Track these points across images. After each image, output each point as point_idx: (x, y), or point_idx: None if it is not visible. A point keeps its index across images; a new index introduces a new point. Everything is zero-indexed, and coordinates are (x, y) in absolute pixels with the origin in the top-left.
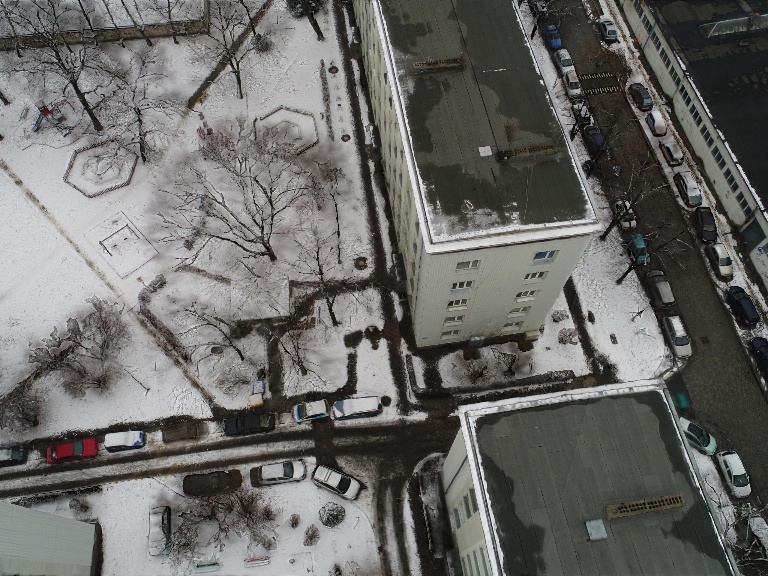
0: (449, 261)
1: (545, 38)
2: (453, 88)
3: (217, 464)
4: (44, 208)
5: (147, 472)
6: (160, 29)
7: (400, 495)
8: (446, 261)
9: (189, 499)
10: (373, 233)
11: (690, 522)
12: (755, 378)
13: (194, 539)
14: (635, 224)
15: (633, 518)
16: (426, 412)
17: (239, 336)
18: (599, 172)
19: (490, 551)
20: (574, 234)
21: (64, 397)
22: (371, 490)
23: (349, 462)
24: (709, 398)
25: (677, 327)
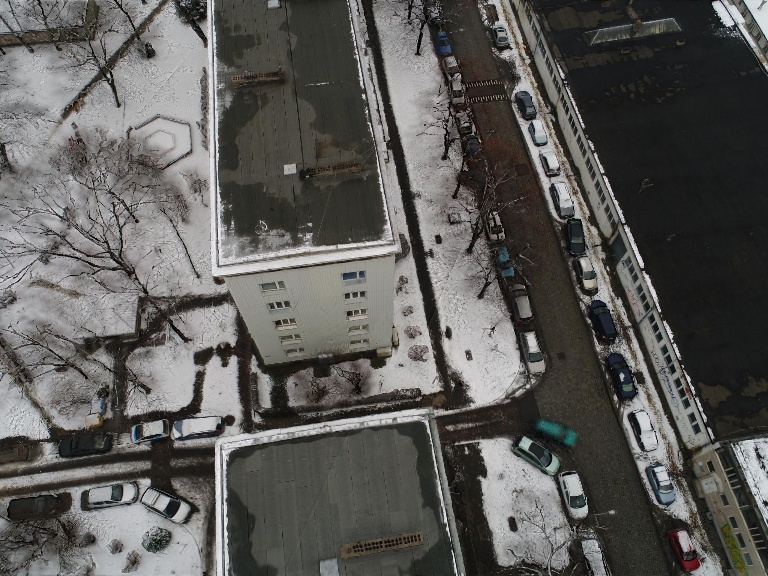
0: (248, 283)
1: (436, 45)
2: (270, 103)
3: (48, 487)
4: None
5: None
6: (41, 35)
7: None
8: (244, 283)
9: (14, 524)
10: None
11: (430, 561)
12: (608, 395)
13: (4, 567)
14: (503, 236)
15: (370, 557)
16: None
17: (85, 354)
18: (472, 183)
19: None
20: (368, 256)
21: None
22: (203, 513)
23: (184, 484)
24: (559, 416)
25: (531, 343)
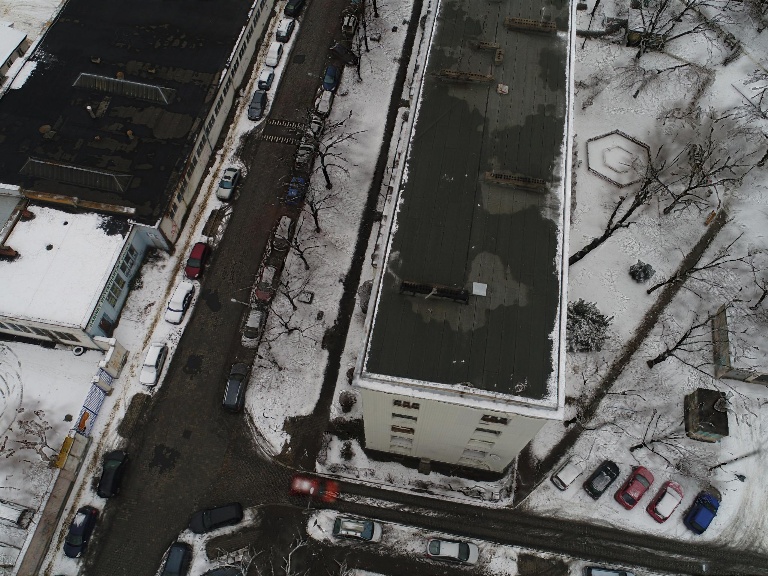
0: None
1: None
2: None
3: None
4: None
5: None
6: None
7: None
8: None
9: None
10: None
11: None
12: None
13: None
14: None
15: None
16: None
17: None
18: None
19: None
20: None
21: None
22: None
23: None
24: None
25: None
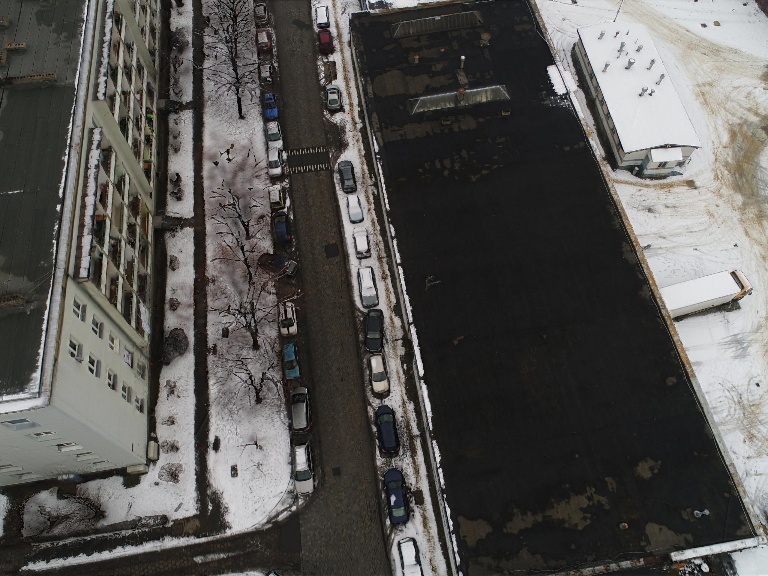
0: None
1: (263, 107)
2: None
3: None
4: None
5: None
6: None
7: None
8: None
9: None
10: None
11: None
12: (380, 518)
13: None
14: (294, 330)
15: None
16: None
17: None
18: (271, 268)
19: None
20: (6, 412)
21: None
22: None
23: None
24: (321, 544)
25: (299, 459)
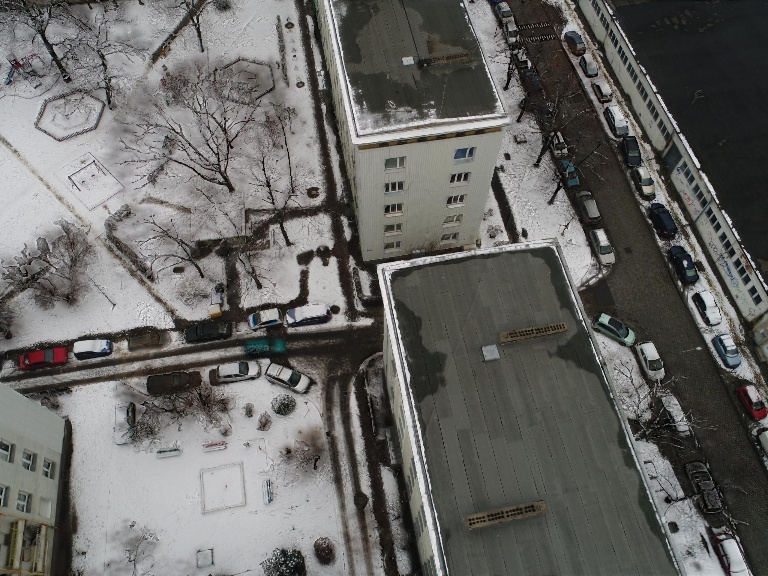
0: (377, 157)
1: None
2: (382, 11)
3: (179, 367)
4: (16, 151)
5: (114, 376)
6: None
7: (347, 388)
8: (374, 157)
9: (152, 397)
10: (325, 166)
11: (572, 346)
12: (672, 281)
13: (155, 424)
14: (566, 152)
15: (523, 343)
16: (372, 318)
17: (199, 257)
18: None
19: (399, 374)
20: (485, 127)
21: (36, 313)
22: (320, 385)
23: (300, 362)
24: (630, 299)
25: (601, 238)
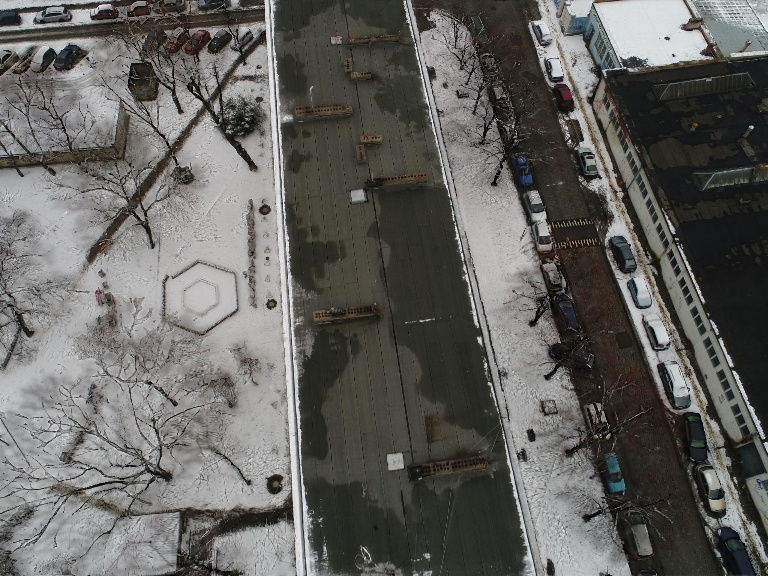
0: None
1: (514, 172)
2: (363, 350)
3: None
4: None
5: None
6: (65, 155)
7: None
8: None
9: None
10: None
11: None
12: None
13: None
14: (609, 435)
15: None
16: None
17: None
18: (569, 361)
19: None
20: None
21: None
22: None
23: None
24: None
25: None
